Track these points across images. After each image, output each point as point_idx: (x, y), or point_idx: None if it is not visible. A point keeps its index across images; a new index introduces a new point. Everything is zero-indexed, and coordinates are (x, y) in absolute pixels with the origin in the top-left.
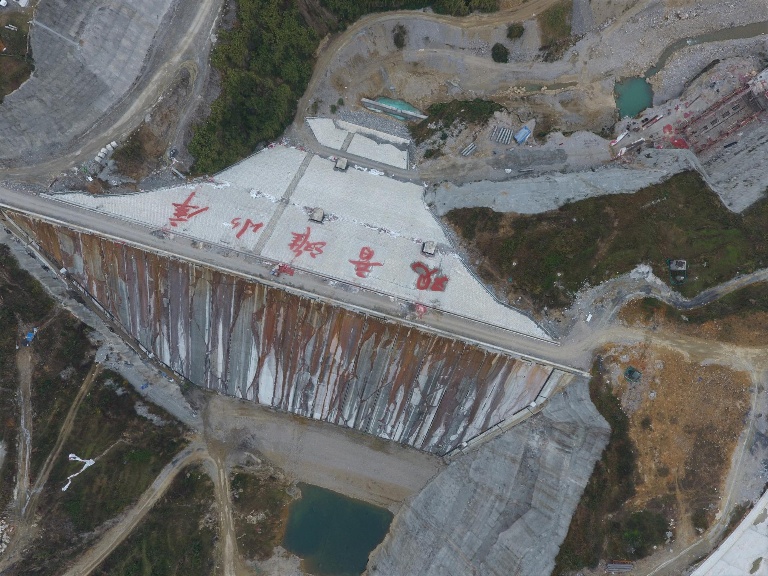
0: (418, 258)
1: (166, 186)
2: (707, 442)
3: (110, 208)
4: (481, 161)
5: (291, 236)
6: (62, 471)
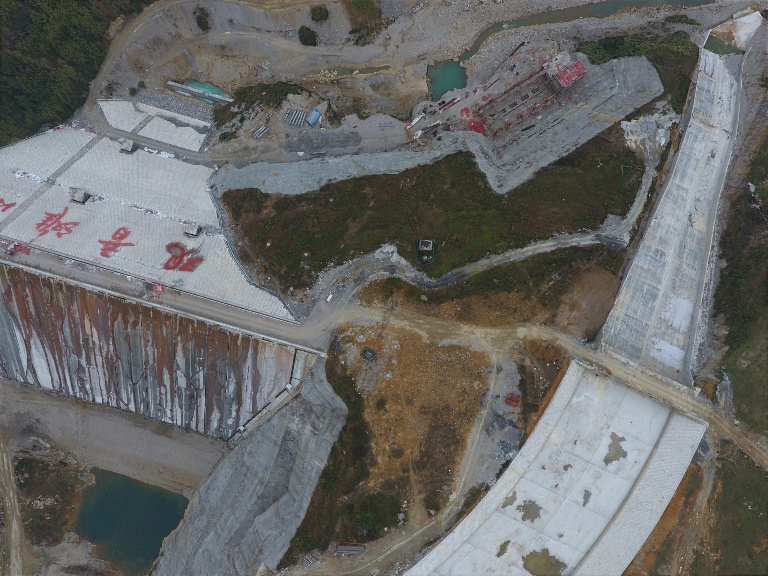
0: (178, 239)
1: None
2: (443, 423)
3: None
4: (273, 144)
5: (43, 216)
6: None
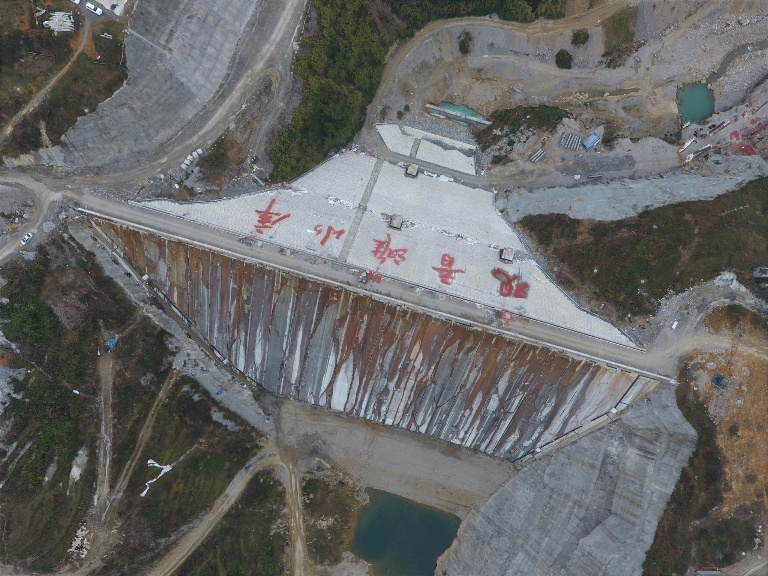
0: (497, 265)
1: (247, 193)
2: None
3: (196, 215)
4: (550, 167)
5: (373, 243)
6: (141, 477)
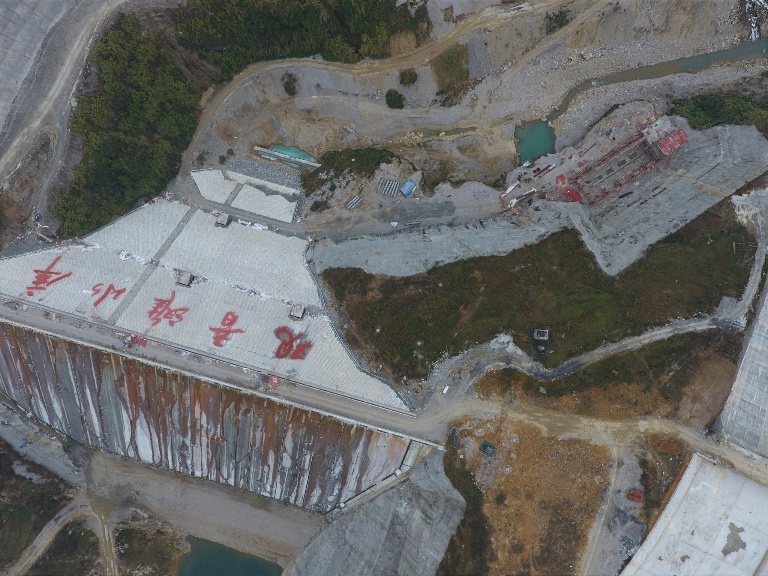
0: (284, 322)
1: (31, 251)
2: (563, 518)
3: None
4: (367, 214)
5: (153, 302)
6: None
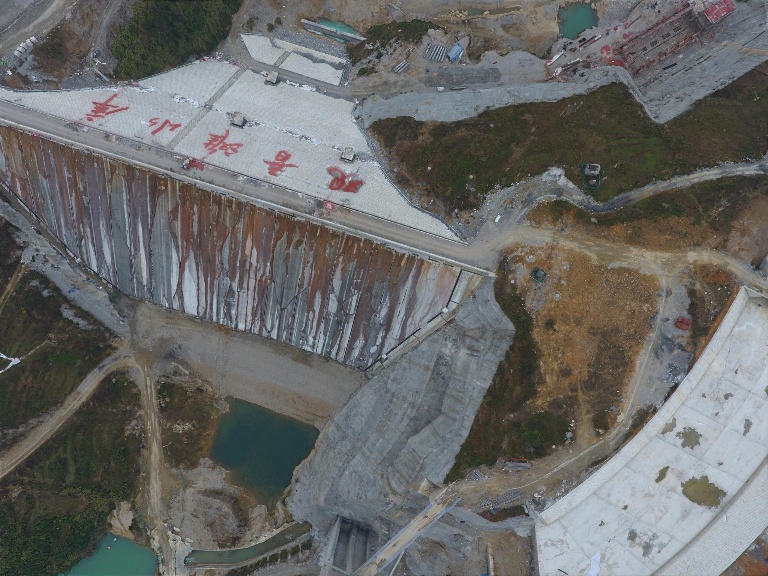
0: (336, 163)
1: (89, 87)
2: (611, 344)
3: (28, 102)
4: (413, 79)
5: (208, 137)
6: None
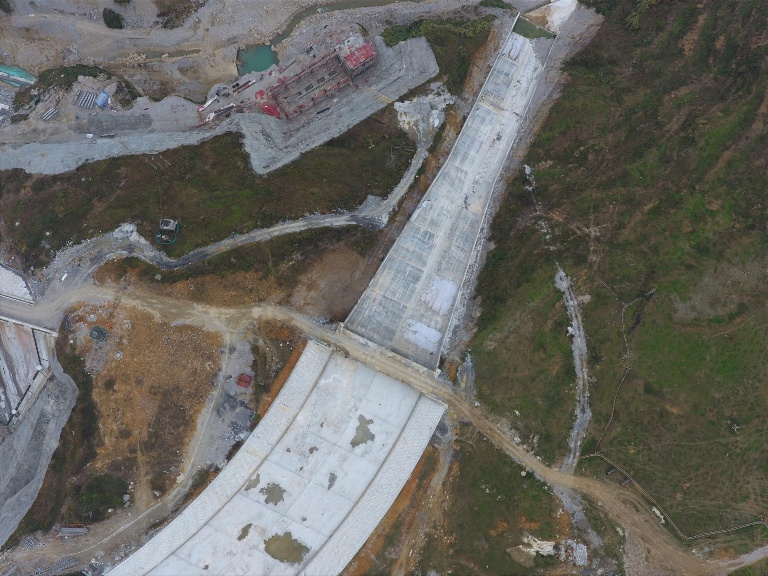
0: None
1: None
2: (172, 404)
3: None
4: (63, 126)
5: None
6: None
